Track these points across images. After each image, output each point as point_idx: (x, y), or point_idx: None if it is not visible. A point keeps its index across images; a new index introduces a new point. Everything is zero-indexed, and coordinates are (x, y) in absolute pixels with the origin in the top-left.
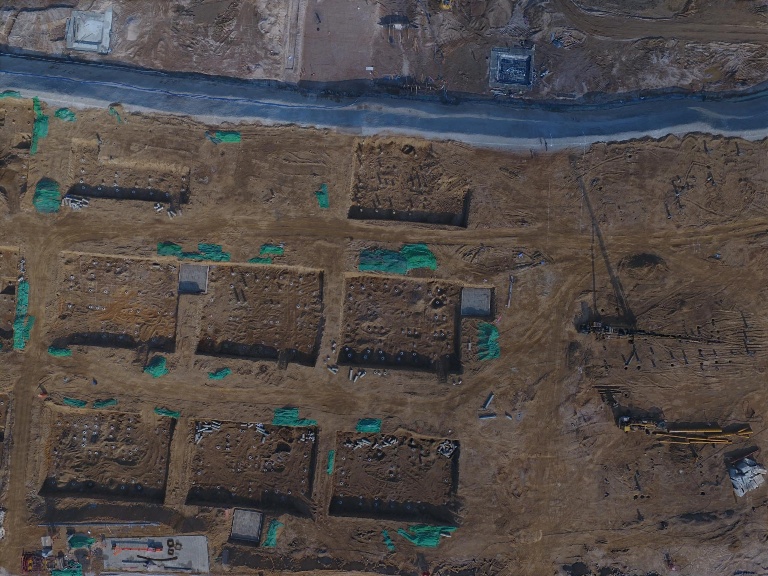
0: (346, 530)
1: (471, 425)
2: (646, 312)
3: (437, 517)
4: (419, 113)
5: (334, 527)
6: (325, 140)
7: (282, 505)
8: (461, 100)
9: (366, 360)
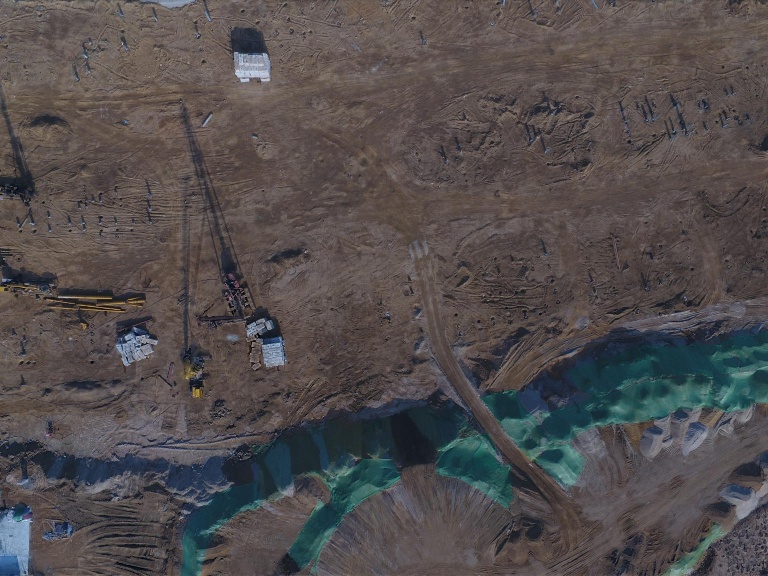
0: None
1: None
2: (45, 175)
3: None
4: None
5: None
6: None
7: None
8: None
9: None
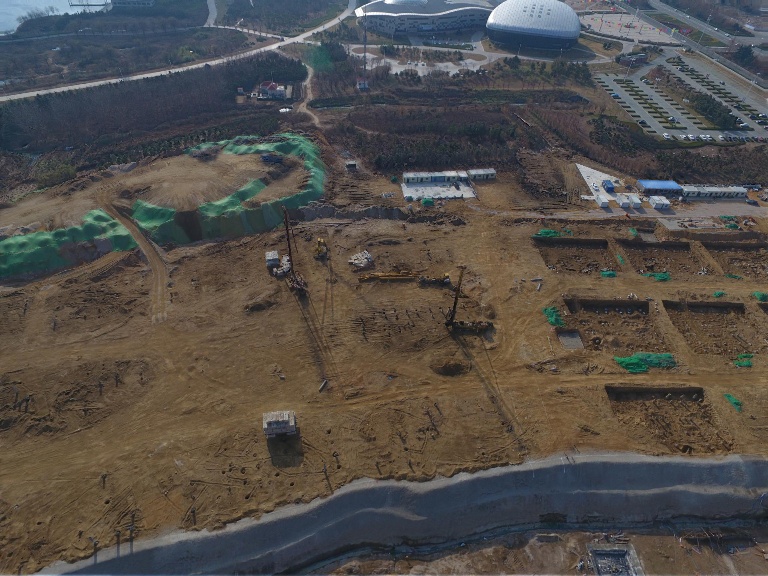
0: (594, 235)
1: (545, 276)
2: (442, 339)
3: (543, 242)
4: (696, 489)
5: (601, 236)
6: (766, 448)
7: (633, 245)
8: (654, 527)
9: (628, 308)
